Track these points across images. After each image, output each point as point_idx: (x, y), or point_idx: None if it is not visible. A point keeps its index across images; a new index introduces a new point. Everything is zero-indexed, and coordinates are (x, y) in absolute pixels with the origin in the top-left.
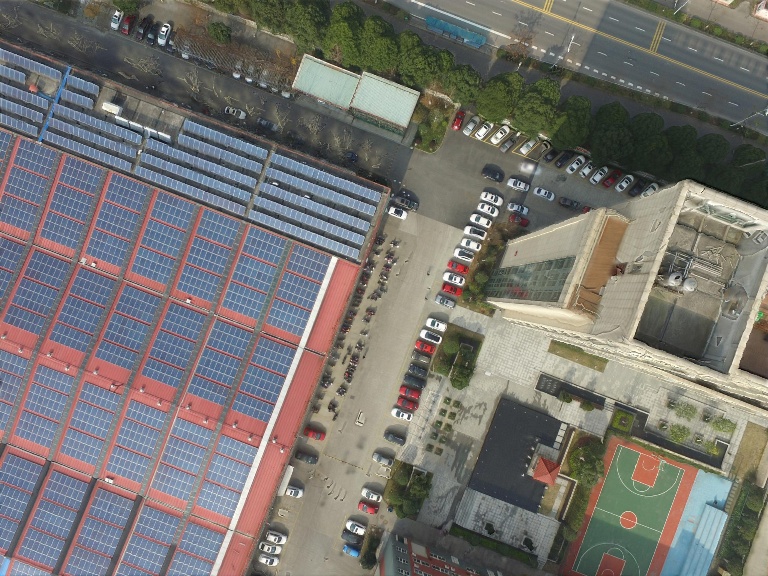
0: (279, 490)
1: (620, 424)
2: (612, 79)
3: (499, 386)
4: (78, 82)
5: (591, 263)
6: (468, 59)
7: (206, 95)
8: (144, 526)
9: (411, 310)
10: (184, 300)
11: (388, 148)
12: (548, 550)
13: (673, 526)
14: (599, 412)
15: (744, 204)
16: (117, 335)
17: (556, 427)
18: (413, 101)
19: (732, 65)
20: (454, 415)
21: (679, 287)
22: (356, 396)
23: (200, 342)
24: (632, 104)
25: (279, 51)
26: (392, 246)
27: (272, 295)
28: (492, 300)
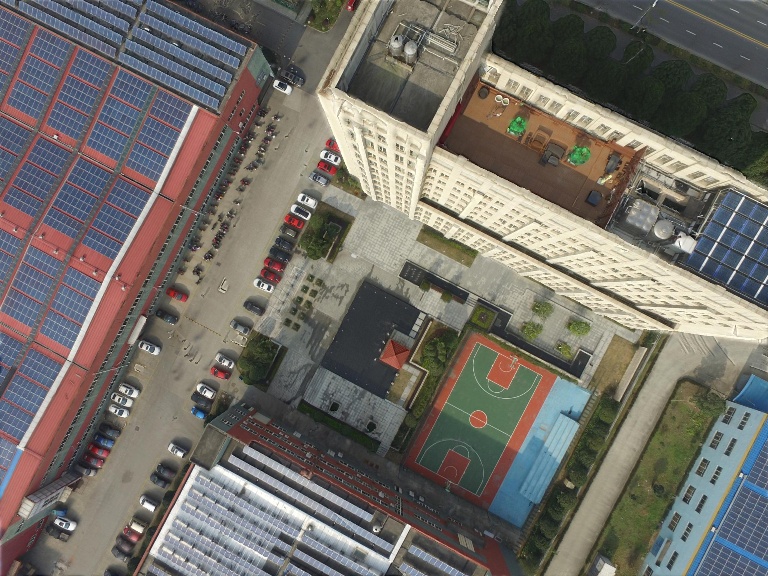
0: (130, 338)
1: (479, 319)
2: None
3: (363, 269)
4: None
5: None
6: None
7: None
8: None
9: (285, 185)
10: (52, 136)
11: (282, 24)
12: (392, 438)
13: (524, 431)
14: (460, 306)
15: None
16: None
17: (414, 316)
18: None
19: None
20: (315, 292)
21: (404, 55)
22: (222, 263)
23: (61, 177)
24: None
25: None
26: (273, 119)
27: (134, 138)
28: None
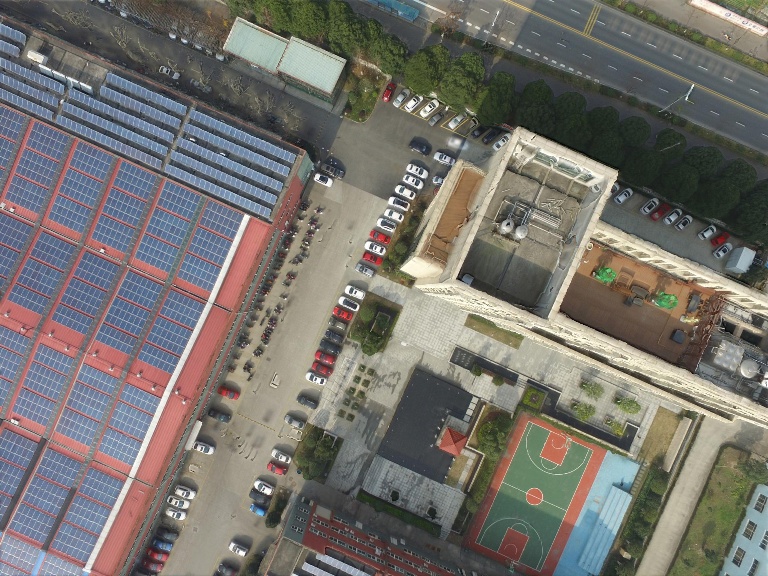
0: (186, 444)
1: (531, 401)
2: (544, 59)
3: (414, 357)
4: (6, 30)
5: (445, 213)
6: (403, 32)
7: (142, 54)
8: (46, 468)
9: (331, 277)
10: (98, 250)
11: (318, 116)
12: (452, 521)
13: (579, 505)
14: (511, 388)
15: (573, 154)
16: (30, 280)
17: (467, 400)
18: (339, 68)
19: (665, 52)
20: (367, 382)
21: (513, 235)
22: (272, 358)
23: (111, 291)
24: (563, 85)
25: (209, 12)
26: (316, 212)
27: (184, 249)
28: (401, 267)
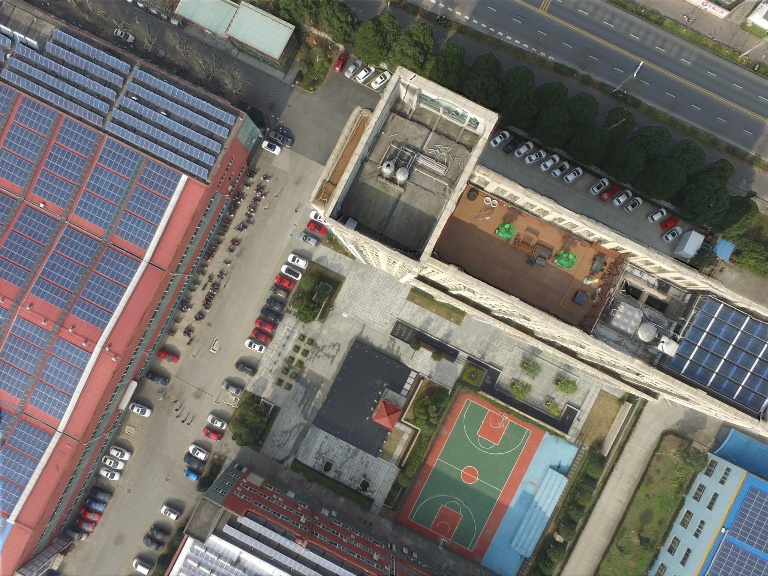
0: (121, 403)
1: (469, 378)
2: (499, 35)
3: (355, 328)
4: None
5: (340, 160)
6: (358, 3)
7: (98, 16)
8: None
9: (275, 245)
10: (38, 204)
11: (270, 83)
12: (385, 495)
13: (514, 486)
14: (450, 364)
15: (453, 95)
16: None
17: (406, 374)
18: (287, 34)
19: (622, 31)
20: (306, 352)
21: None
22: (213, 324)
23: (49, 246)
24: (516, 61)
25: None
26: (262, 179)
27: (122, 207)
28: None
